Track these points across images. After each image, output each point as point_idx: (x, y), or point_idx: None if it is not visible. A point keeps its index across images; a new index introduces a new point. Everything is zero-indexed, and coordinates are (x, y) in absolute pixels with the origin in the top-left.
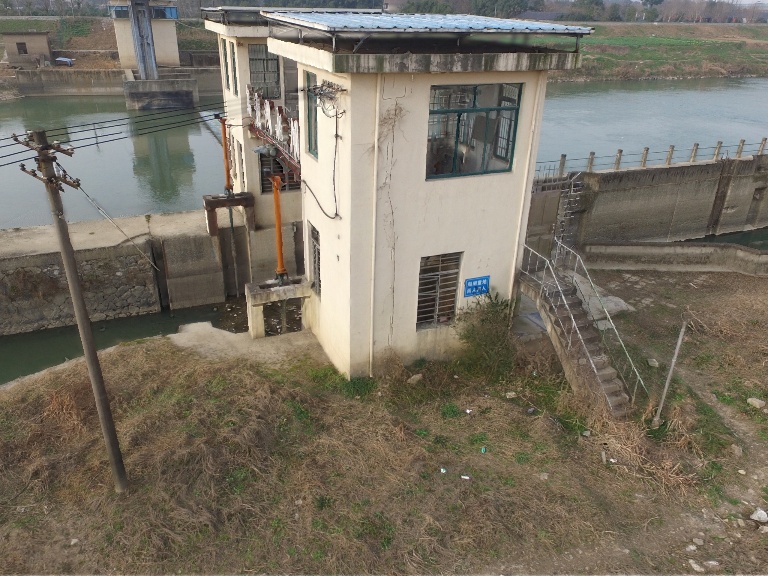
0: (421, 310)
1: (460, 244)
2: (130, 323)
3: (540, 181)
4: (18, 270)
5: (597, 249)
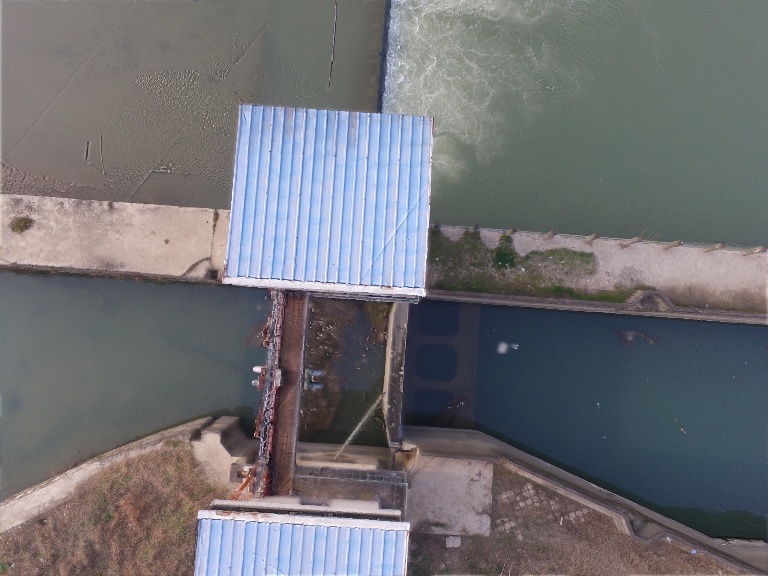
0: None
1: None
2: (207, 283)
3: None
4: None
5: None
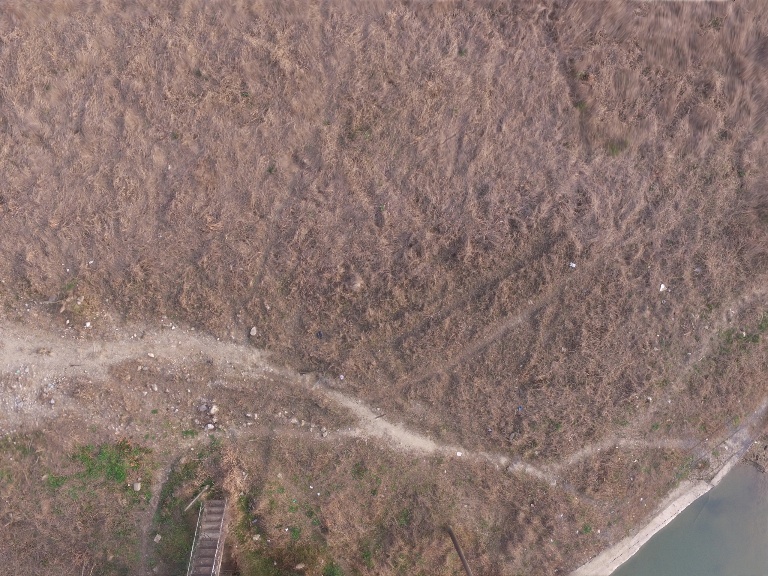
0: None
1: None
2: None
3: None
4: None
5: None
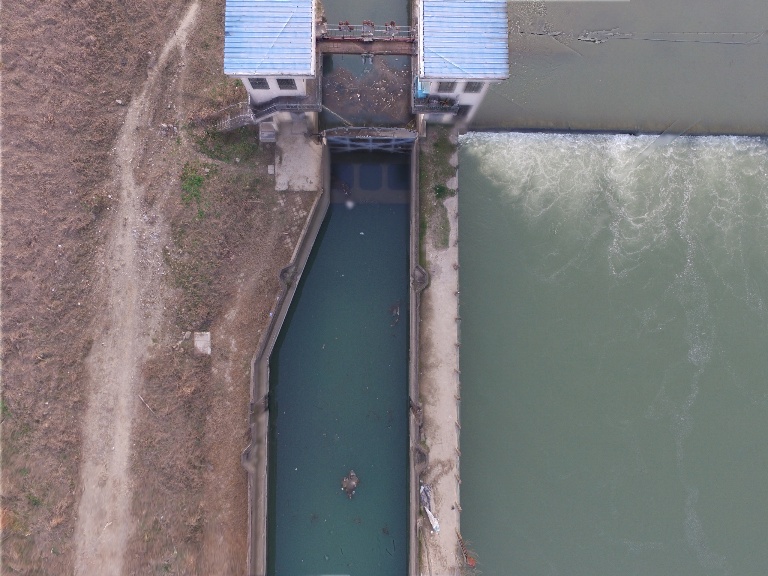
0: None
1: None
2: None
3: None
4: None
5: None
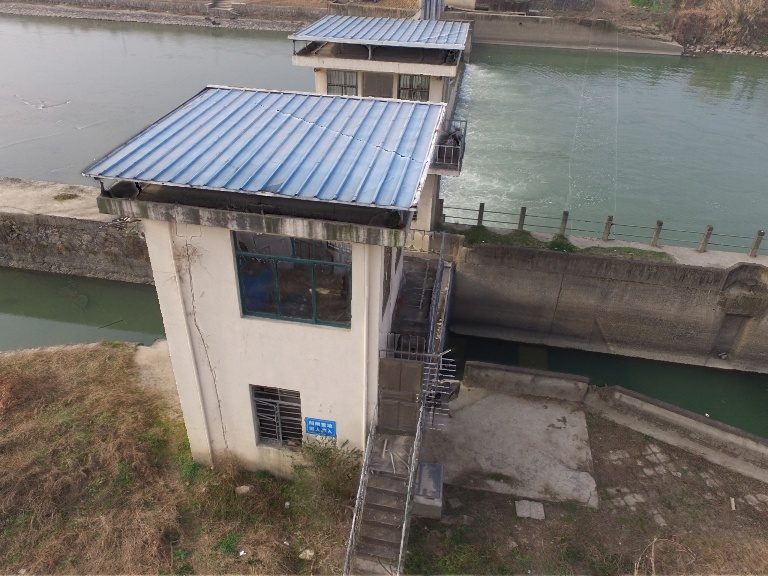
0: (264, 427)
1: (293, 383)
2: None
3: (391, 347)
4: (131, 235)
5: (630, 400)
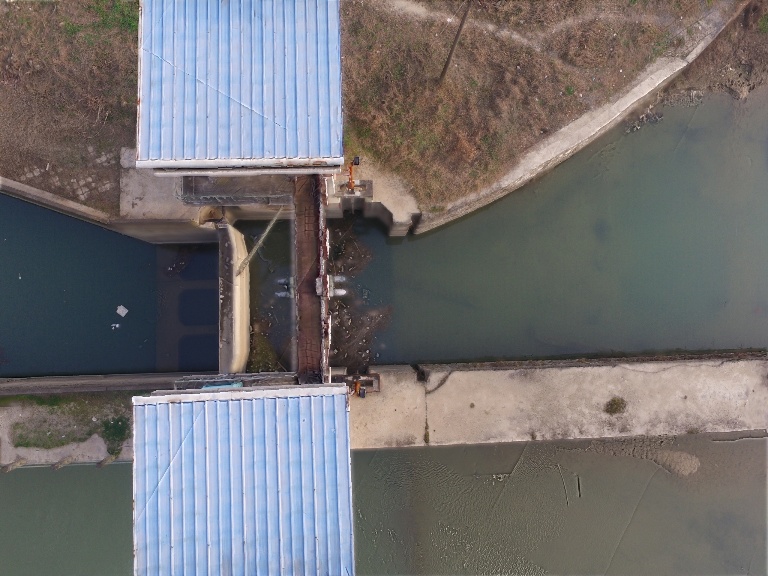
0: None
1: None
2: None
3: None
4: None
5: None
